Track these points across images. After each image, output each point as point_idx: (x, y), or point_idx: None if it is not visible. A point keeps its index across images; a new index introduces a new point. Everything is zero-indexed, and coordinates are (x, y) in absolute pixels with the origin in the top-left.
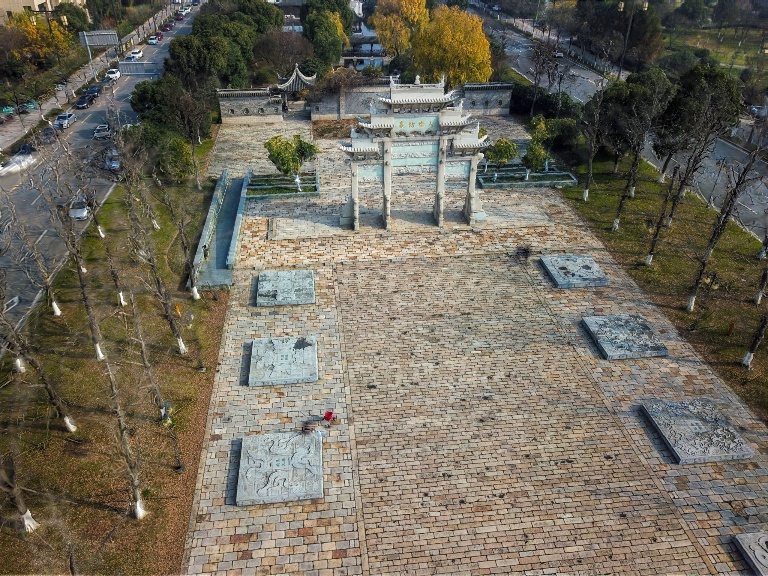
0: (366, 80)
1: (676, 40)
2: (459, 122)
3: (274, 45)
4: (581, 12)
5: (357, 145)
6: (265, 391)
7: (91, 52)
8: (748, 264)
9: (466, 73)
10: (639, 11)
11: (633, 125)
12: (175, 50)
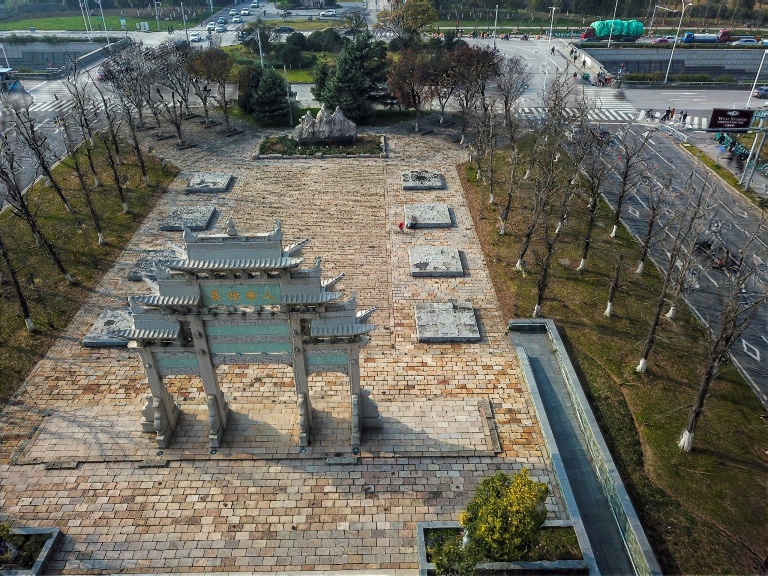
0: None
1: None
2: None
3: None
4: None
5: None
6: None
7: None
8: None
9: None
10: None
11: None
12: None
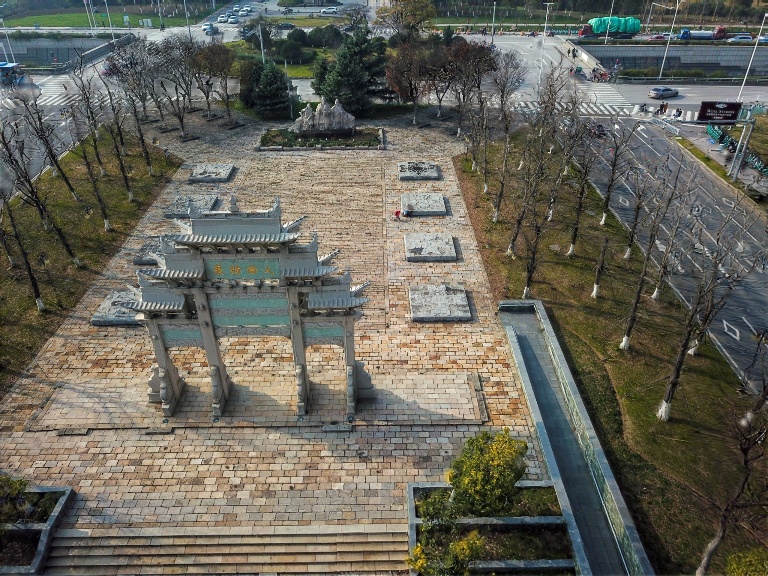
0: None
1: None
2: None
3: None
4: None
5: None
6: None
7: None
8: None
9: None
10: None
11: None
12: None
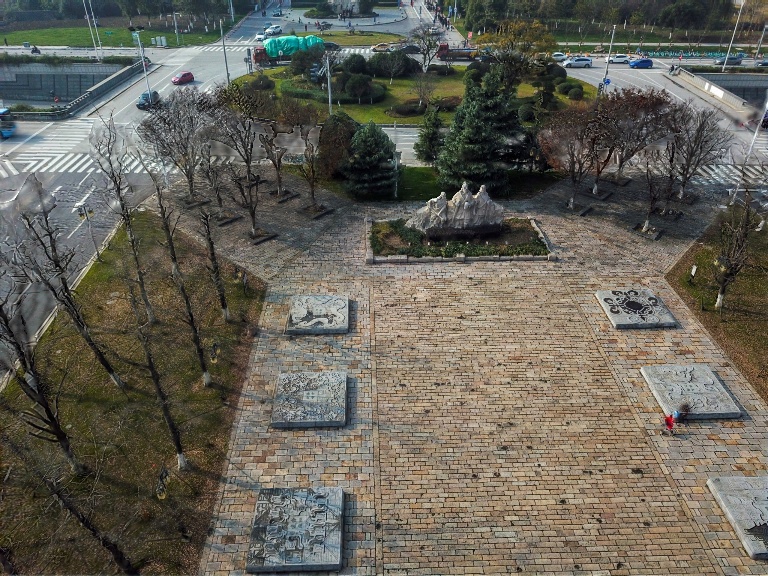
0: None
1: None
2: None
3: None
4: None
5: None
6: (762, 473)
7: None
8: None
9: None
10: None
11: None
12: None
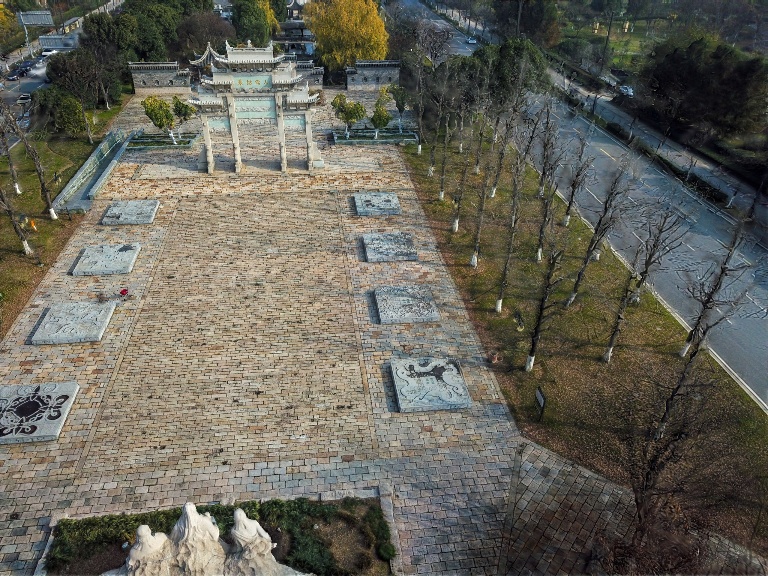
0: None
1: (582, 30)
2: (289, 81)
3: (197, 26)
4: (498, 3)
5: (204, 99)
6: (85, 279)
7: (35, 33)
8: (525, 201)
9: (362, 53)
10: (538, 1)
11: None
12: (87, 25)
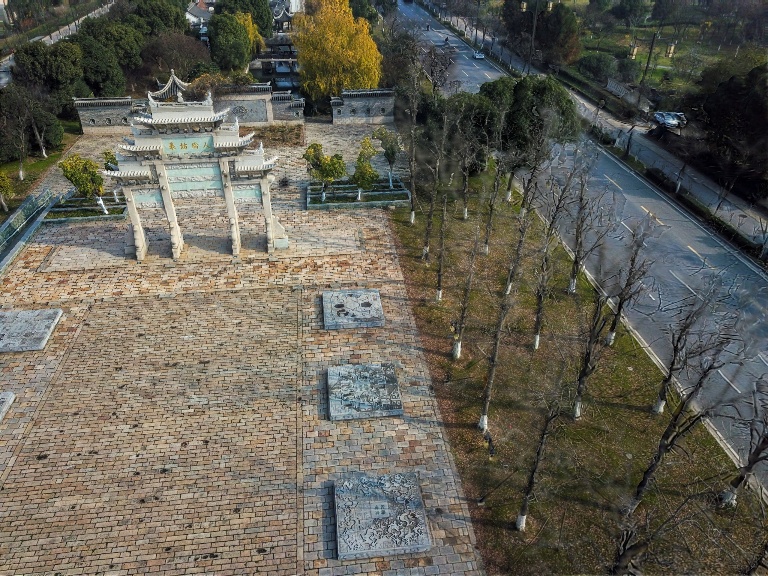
0: (234, 88)
1: (604, 40)
2: (236, 143)
3: (164, 49)
4: (508, 11)
5: (125, 168)
6: None
7: None
8: (551, 299)
9: (351, 79)
10: (554, 11)
11: (468, 140)
12: (19, 58)
